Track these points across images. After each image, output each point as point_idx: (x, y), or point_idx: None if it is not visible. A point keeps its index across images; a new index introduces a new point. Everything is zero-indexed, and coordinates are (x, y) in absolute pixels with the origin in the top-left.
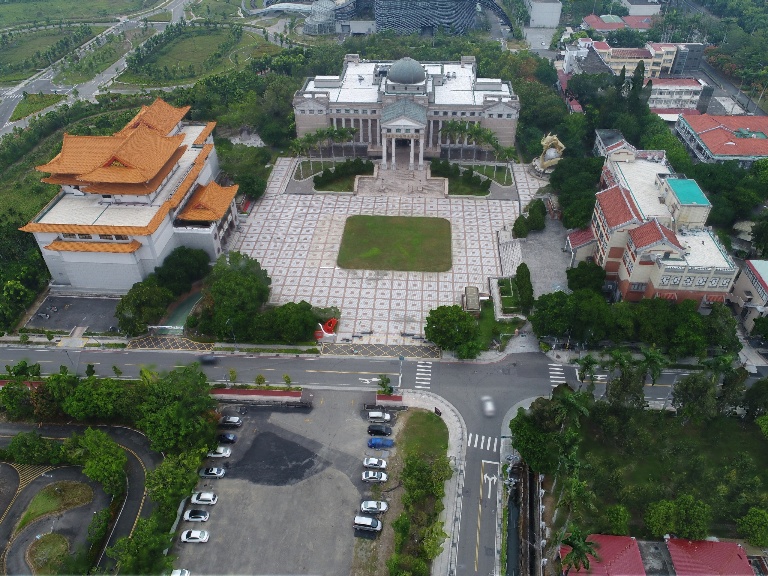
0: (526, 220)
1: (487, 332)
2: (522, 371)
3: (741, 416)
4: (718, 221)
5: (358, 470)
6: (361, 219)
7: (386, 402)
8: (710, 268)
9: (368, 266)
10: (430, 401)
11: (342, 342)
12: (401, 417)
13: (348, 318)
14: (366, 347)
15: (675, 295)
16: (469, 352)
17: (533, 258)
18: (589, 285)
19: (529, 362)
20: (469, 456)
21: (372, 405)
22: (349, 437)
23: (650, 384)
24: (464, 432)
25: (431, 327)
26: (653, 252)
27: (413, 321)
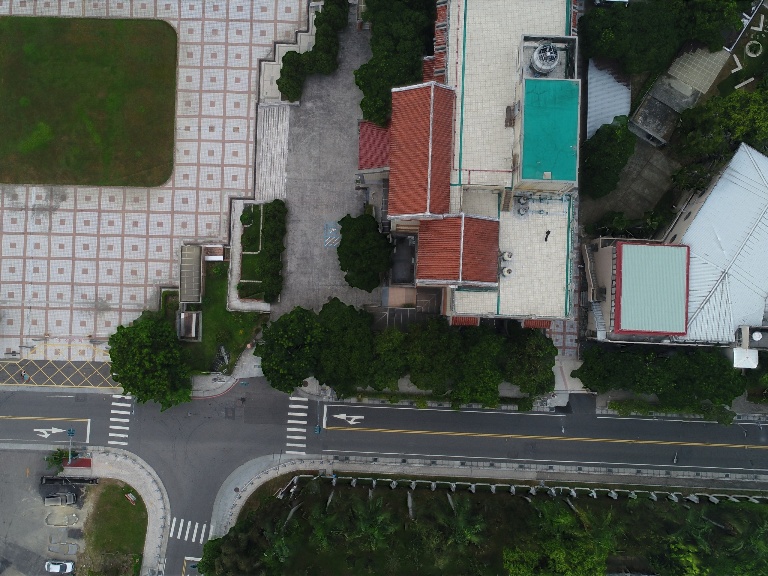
0: (300, 60)
1: (213, 333)
2: (251, 413)
3: (510, 491)
4: (640, 72)
5: (42, 572)
6: (13, 32)
7: (70, 470)
8: (528, 317)
9: (33, 176)
10: (127, 467)
11: (6, 357)
12: (90, 494)
13: (11, 306)
14: (41, 367)
15: (477, 320)
16: (171, 405)
17: (305, 154)
18: (359, 278)
19: (263, 395)
20: (170, 552)
21: (51, 479)
22: (28, 526)
23: (417, 431)
24: (167, 516)
25: (113, 368)
26: (444, 284)
27: (108, 309)
